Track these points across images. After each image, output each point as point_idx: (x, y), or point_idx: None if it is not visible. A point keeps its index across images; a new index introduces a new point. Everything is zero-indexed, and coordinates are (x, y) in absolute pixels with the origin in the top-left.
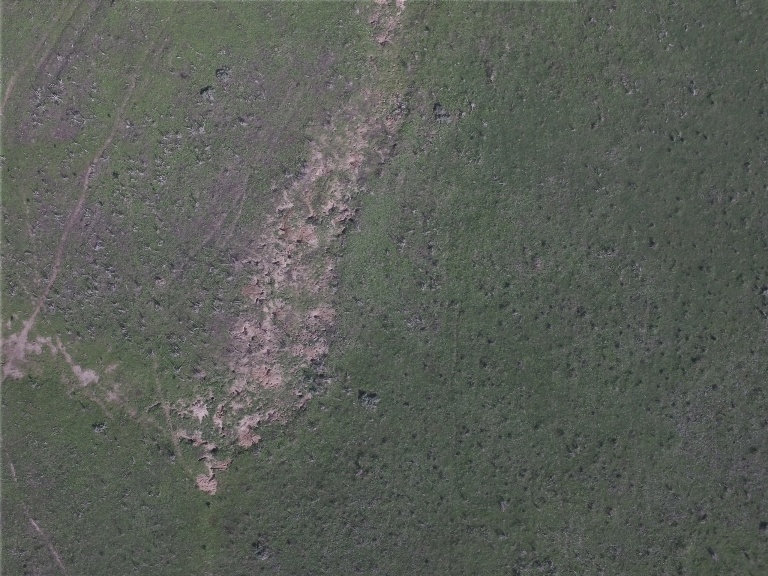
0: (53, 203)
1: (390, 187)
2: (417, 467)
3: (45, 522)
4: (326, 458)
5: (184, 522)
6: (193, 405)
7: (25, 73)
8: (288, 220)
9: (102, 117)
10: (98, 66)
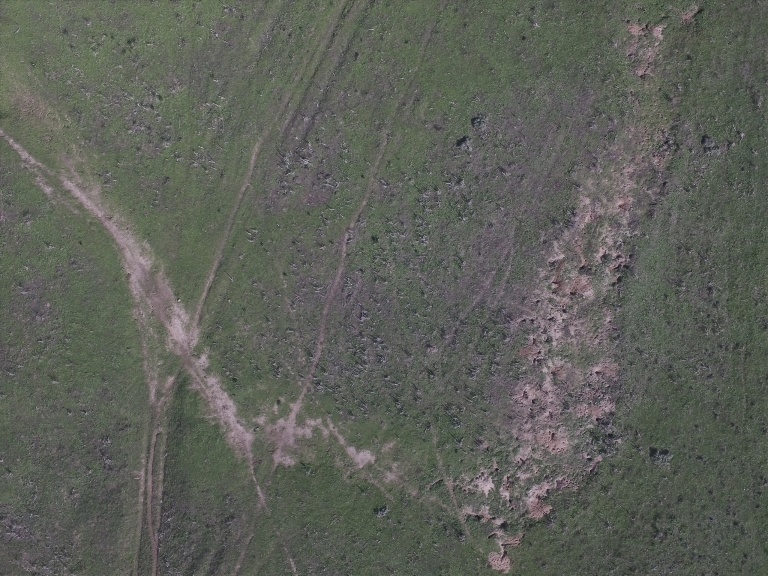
0: (311, 275)
1: (664, 228)
2: (716, 524)
3: None
4: (621, 523)
5: None
6: (477, 479)
7: (270, 138)
8: (561, 272)
9: (355, 179)
10: (346, 125)
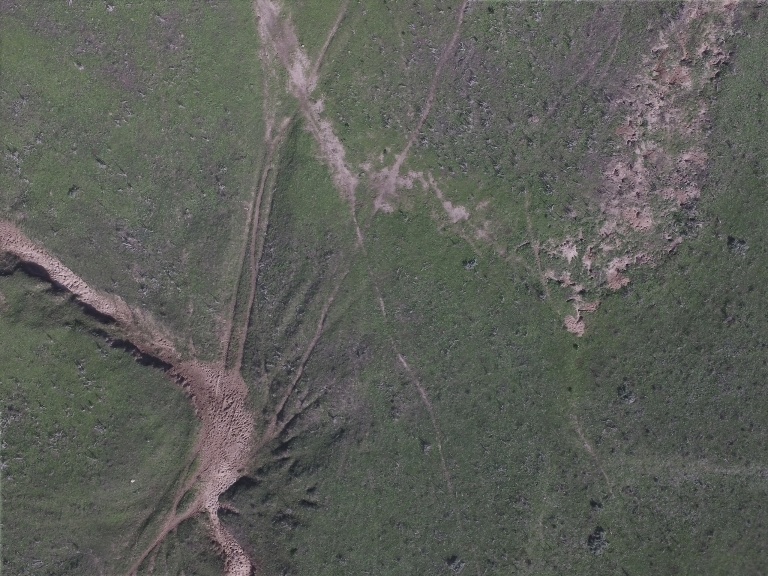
0: (428, 37)
1: (766, 31)
2: None
3: (412, 358)
4: (693, 304)
5: (550, 363)
6: (562, 246)
7: None
8: (663, 61)
9: None
10: None
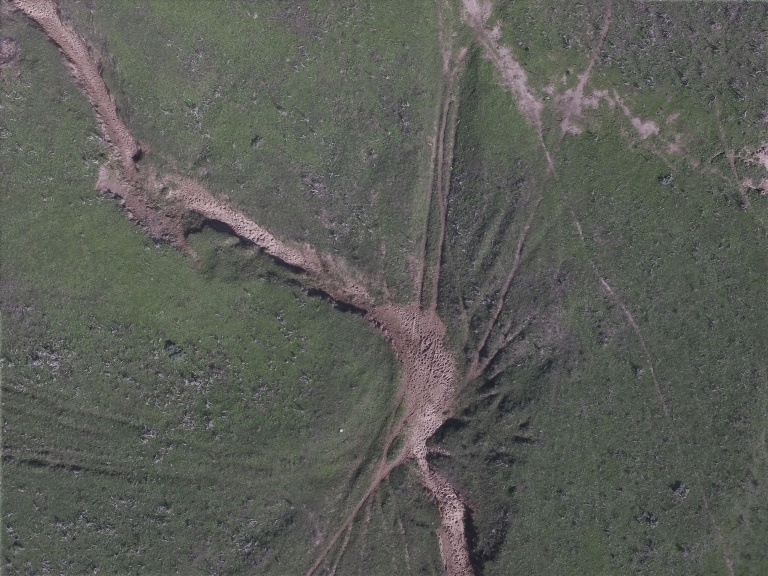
0: None
1: None
2: None
3: (614, 281)
4: None
5: (757, 274)
6: (757, 152)
7: None
8: None
9: None
10: None
